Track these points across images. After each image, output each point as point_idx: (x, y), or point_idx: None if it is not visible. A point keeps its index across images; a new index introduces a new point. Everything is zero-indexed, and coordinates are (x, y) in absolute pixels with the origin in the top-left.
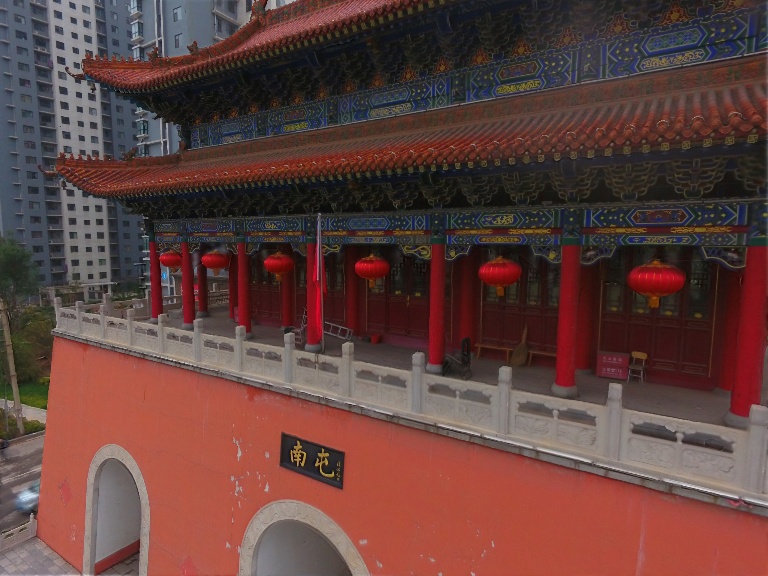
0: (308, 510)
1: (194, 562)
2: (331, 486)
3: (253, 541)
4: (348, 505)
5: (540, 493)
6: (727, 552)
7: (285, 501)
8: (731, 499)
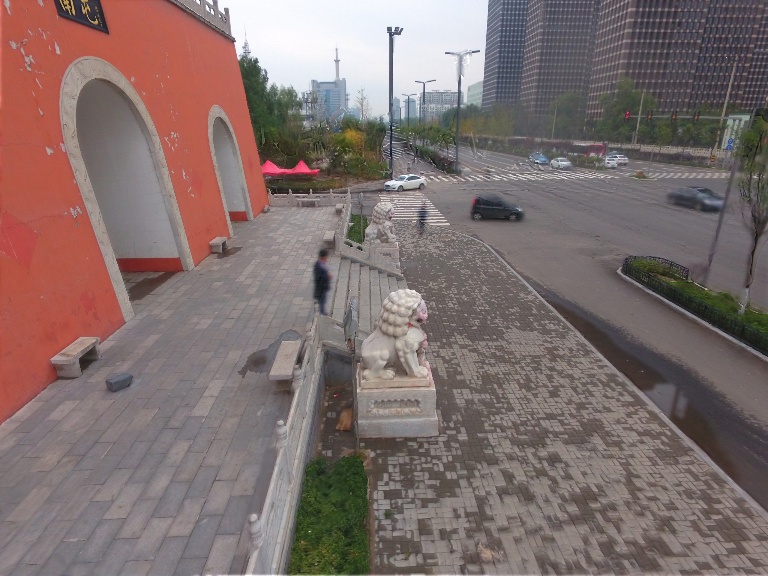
0: (98, 64)
1: (17, 215)
2: (103, 32)
3: (73, 125)
4: (116, 49)
5: (167, 18)
6: (195, 35)
7: (80, 60)
8: (192, 11)
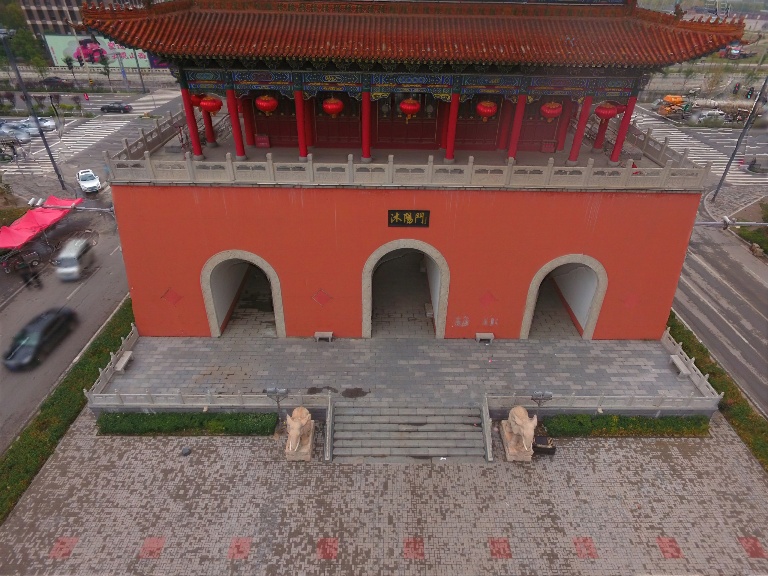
0: None
1: None
2: None
3: None
4: None
5: None
6: None
7: None
8: None
